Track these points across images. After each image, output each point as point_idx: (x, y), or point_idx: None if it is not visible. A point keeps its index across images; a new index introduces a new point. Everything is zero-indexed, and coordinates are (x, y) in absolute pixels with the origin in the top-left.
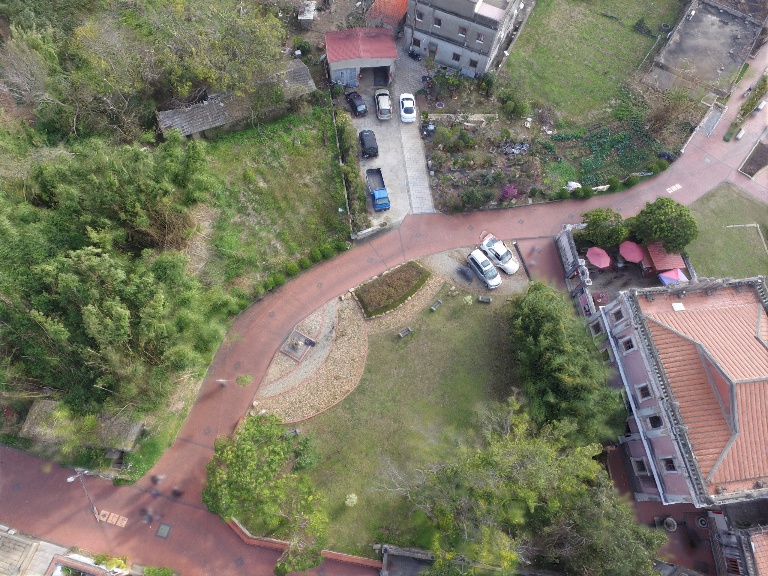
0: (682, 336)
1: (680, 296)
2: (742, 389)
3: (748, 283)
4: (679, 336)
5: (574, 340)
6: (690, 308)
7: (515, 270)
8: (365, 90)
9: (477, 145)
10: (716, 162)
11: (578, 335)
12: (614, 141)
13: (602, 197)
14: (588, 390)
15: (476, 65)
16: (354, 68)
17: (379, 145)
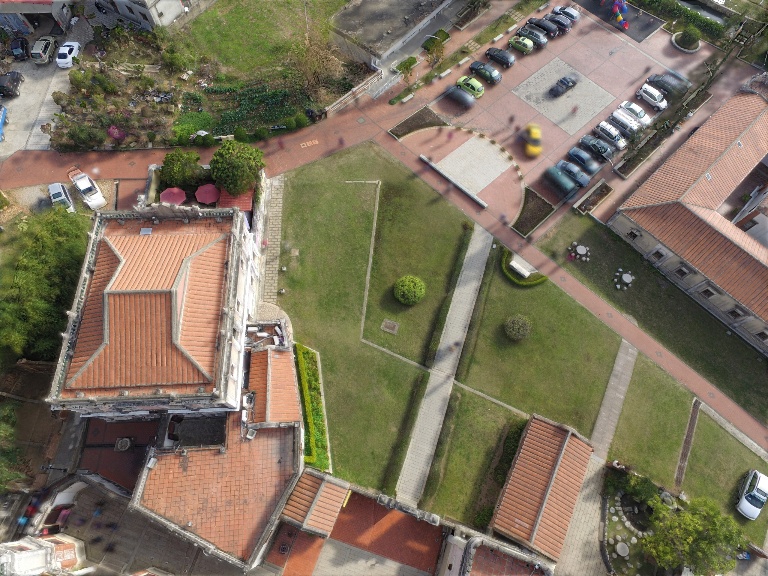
0: (115, 254)
1: (153, 222)
2: (116, 300)
3: (230, 215)
4: (114, 254)
5: (44, 258)
6: (157, 233)
7: (100, 206)
8: (39, 37)
9: (120, 92)
10: (369, 123)
11: (52, 254)
12: (266, 96)
13: None
14: (22, 301)
15: (147, 18)
16: (14, 13)
17: (25, 87)
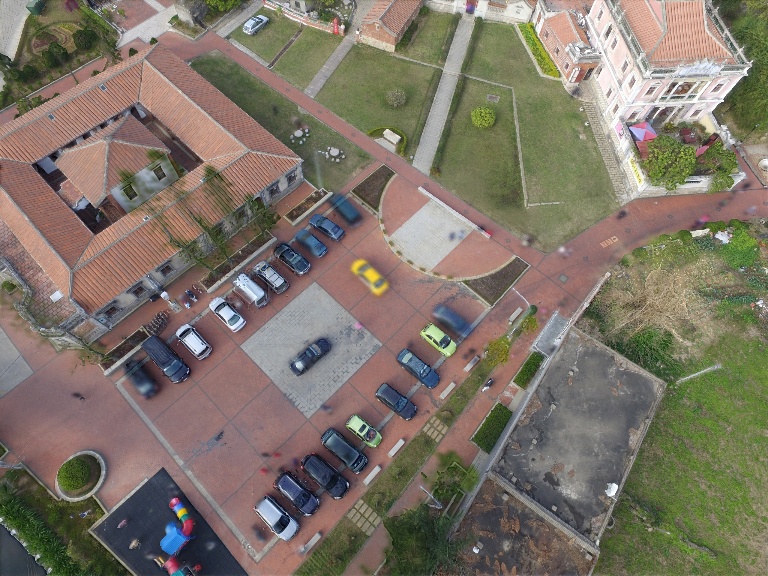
0: None
1: None
2: None
3: None
4: None
5: (763, 62)
6: None
7: (762, 162)
8: None
9: None
10: (554, 276)
11: (760, 65)
12: None
13: (689, 229)
14: (753, 34)
15: None
16: None
17: None
